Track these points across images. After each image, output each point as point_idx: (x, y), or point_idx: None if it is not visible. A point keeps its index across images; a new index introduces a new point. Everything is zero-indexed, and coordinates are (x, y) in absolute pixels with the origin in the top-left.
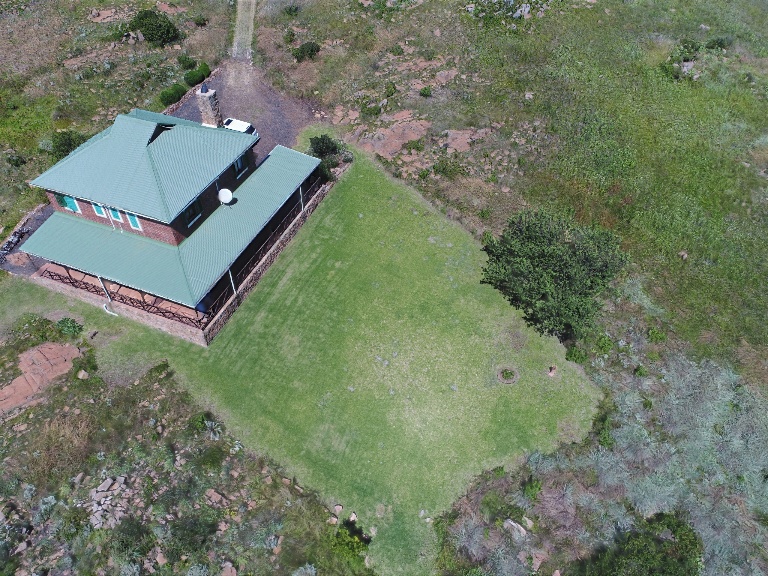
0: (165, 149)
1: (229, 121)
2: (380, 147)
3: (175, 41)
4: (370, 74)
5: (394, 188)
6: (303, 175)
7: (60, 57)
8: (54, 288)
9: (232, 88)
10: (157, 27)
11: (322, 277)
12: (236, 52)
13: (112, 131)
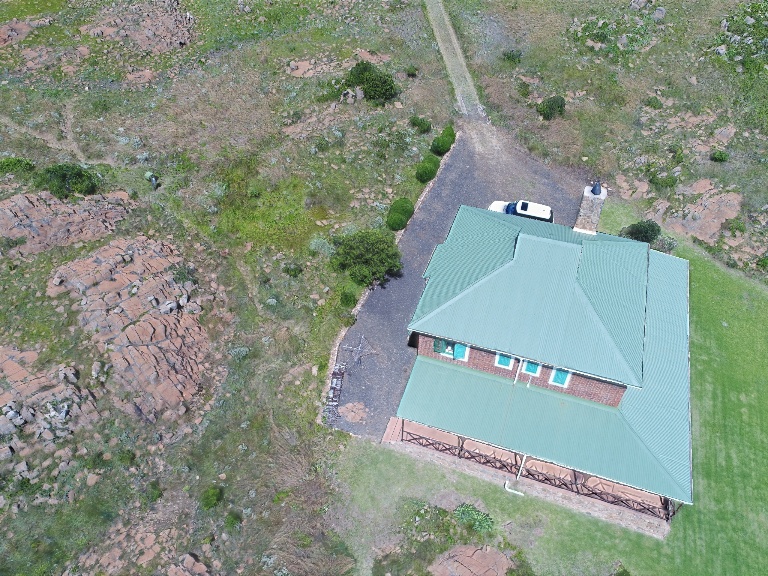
0: (590, 278)
1: (524, 204)
2: (696, 228)
3: (395, 97)
4: (637, 133)
5: (737, 282)
6: (684, 284)
7: (277, 123)
8: (421, 456)
9: (484, 155)
10: (381, 83)
11: (738, 419)
12: (465, 108)
13: (517, 256)
